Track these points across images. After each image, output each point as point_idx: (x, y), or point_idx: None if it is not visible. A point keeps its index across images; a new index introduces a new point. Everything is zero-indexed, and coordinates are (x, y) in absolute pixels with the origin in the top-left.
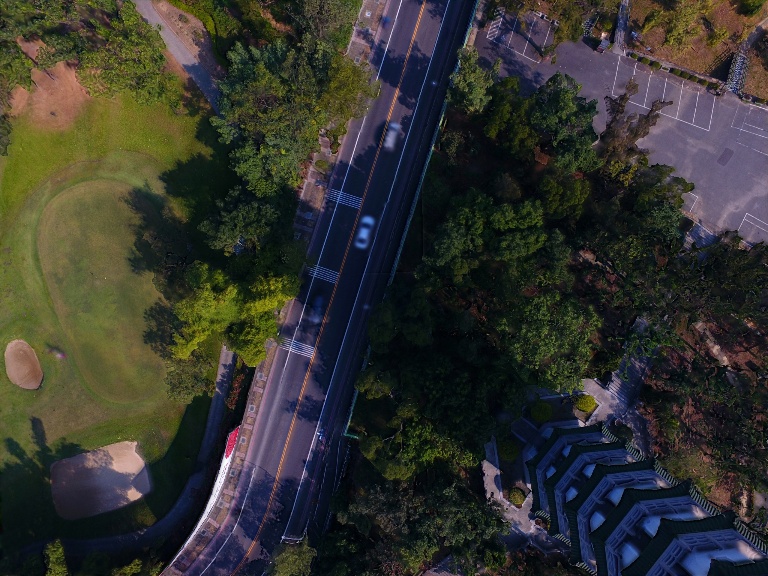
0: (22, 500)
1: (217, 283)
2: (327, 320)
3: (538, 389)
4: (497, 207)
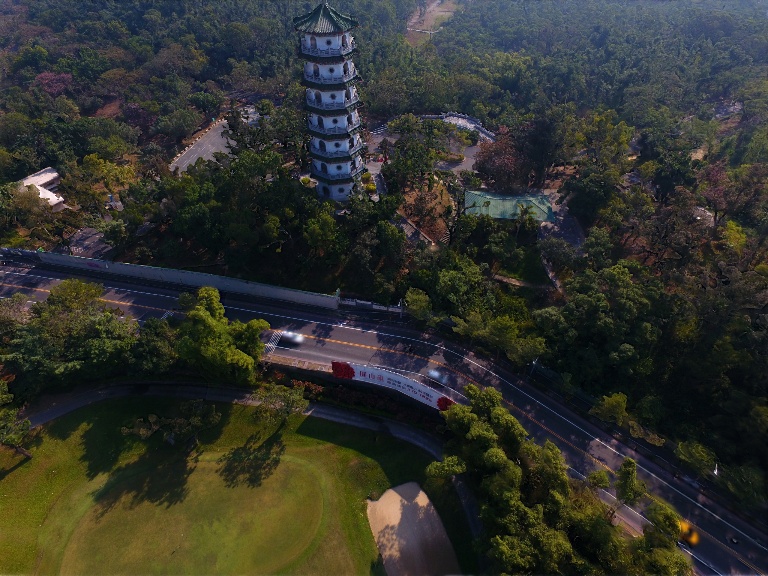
0: None
1: None
2: None
3: None
4: None
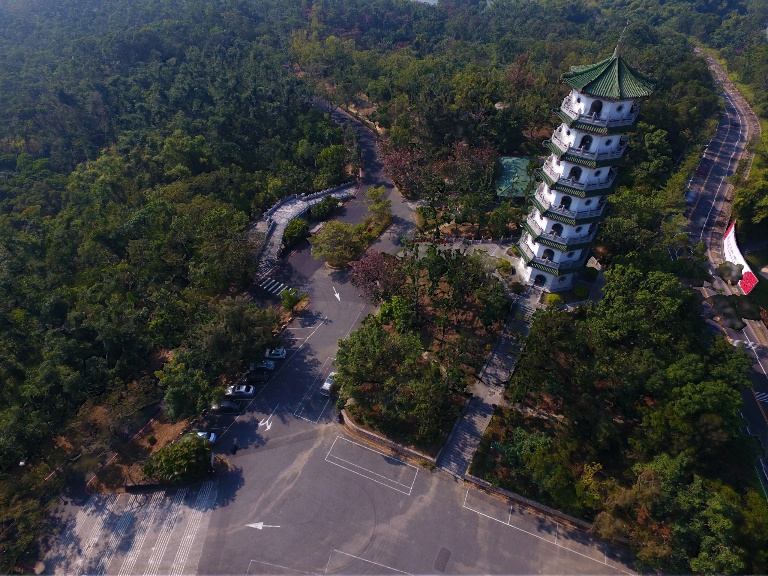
0: None
1: None
2: None
3: None
4: None
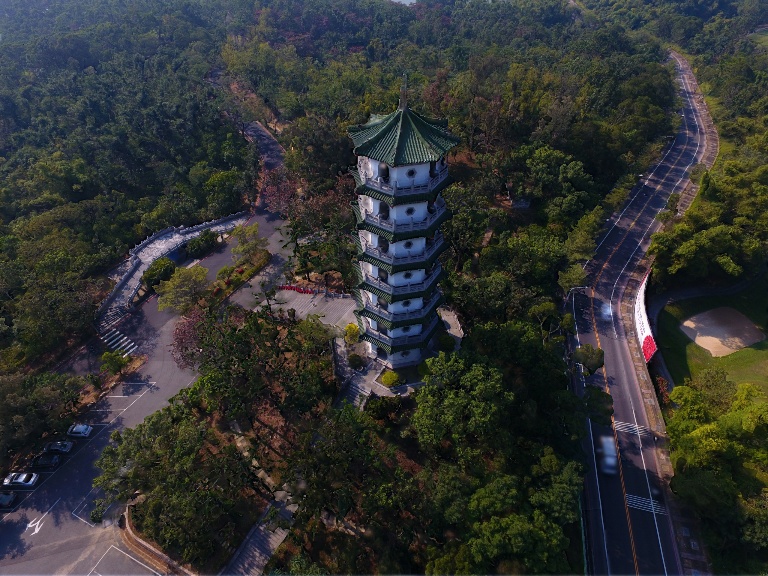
0: (767, 316)
1: (759, 450)
2: (617, 456)
3: None
4: None
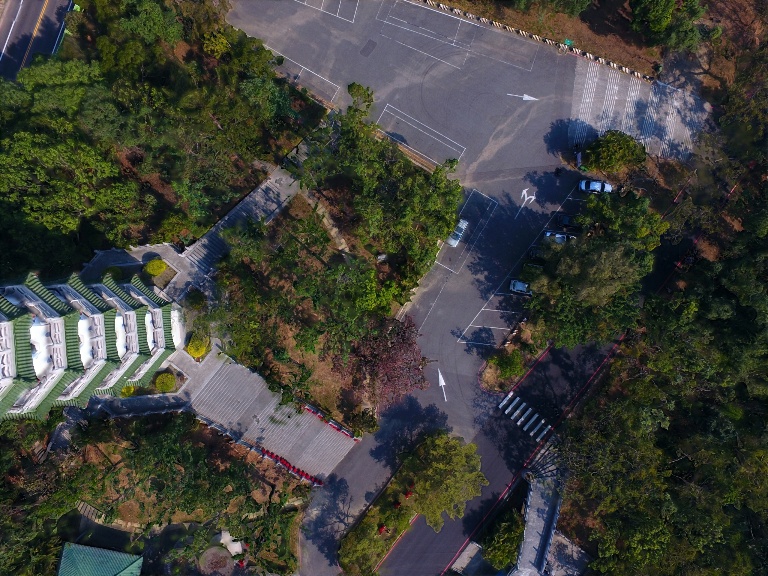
0: None
1: None
2: None
3: (118, 256)
4: (43, 63)
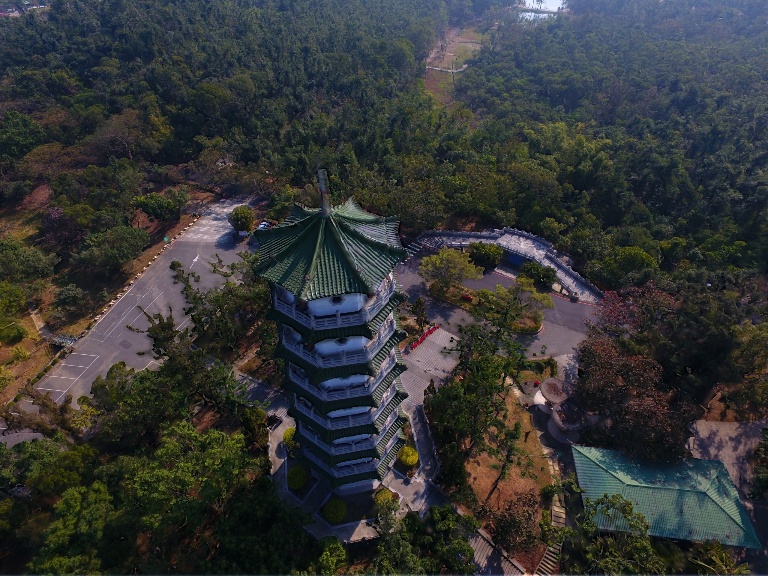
0: None
1: None
2: None
3: (277, 483)
4: (44, 540)
